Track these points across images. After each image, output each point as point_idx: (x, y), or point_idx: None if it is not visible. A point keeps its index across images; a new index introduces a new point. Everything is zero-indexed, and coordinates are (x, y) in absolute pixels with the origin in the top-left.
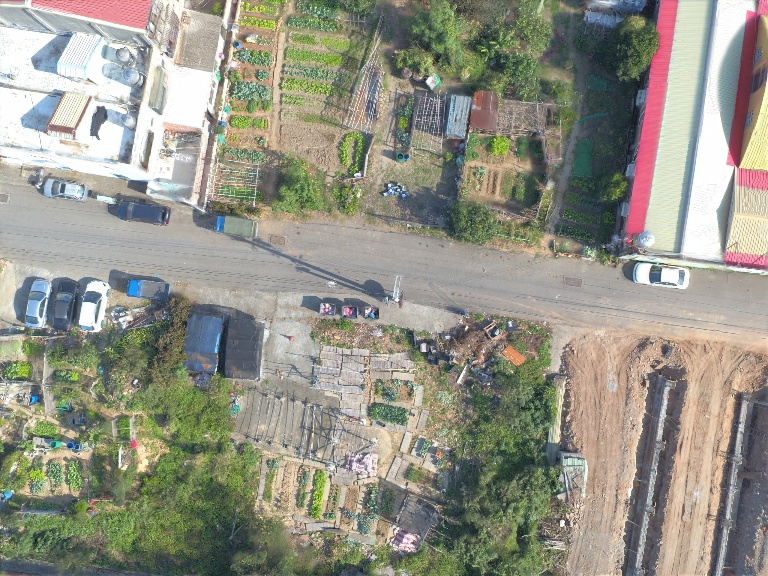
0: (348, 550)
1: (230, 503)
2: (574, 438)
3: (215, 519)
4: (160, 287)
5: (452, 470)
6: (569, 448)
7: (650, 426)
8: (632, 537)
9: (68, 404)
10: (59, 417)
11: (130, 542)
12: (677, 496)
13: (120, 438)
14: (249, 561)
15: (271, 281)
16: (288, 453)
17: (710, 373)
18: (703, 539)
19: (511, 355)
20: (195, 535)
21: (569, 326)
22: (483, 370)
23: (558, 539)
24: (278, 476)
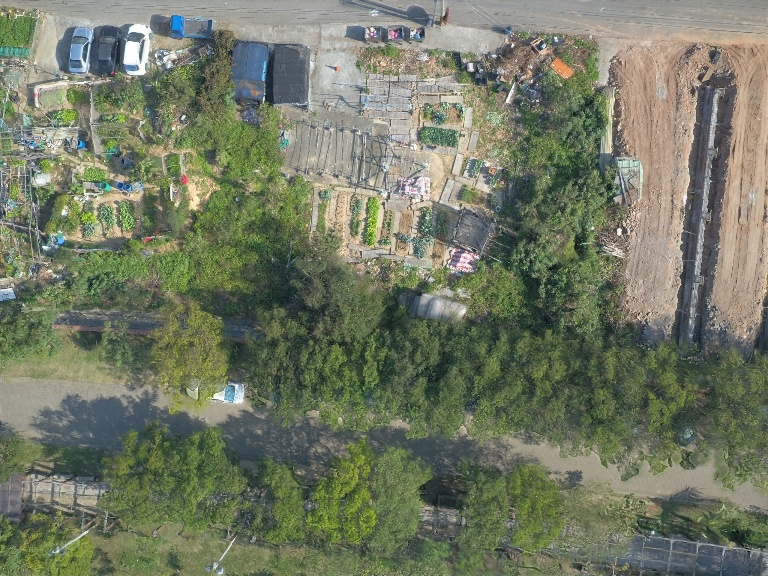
0: (405, 275)
1: (284, 235)
2: (627, 146)
3: (270, 252)
4: (203, 25)
5: (505, 189)
6: (622, 156)
7: (701, 137)
8: (689, 248)
9: (116, 148)
10: (107, 162)
11: (185, 282)
12: (732, 199)
13: (170, 175)
14: (310, 270)
15: (314, 14)
16: (340, 183)
17: (759, 76)
18: (761, 241)
19: (559, 68)
20: (251, 269)
21: (615, 38)
22: (531, 85)
23: (616, 247)
24: (331, 207)
